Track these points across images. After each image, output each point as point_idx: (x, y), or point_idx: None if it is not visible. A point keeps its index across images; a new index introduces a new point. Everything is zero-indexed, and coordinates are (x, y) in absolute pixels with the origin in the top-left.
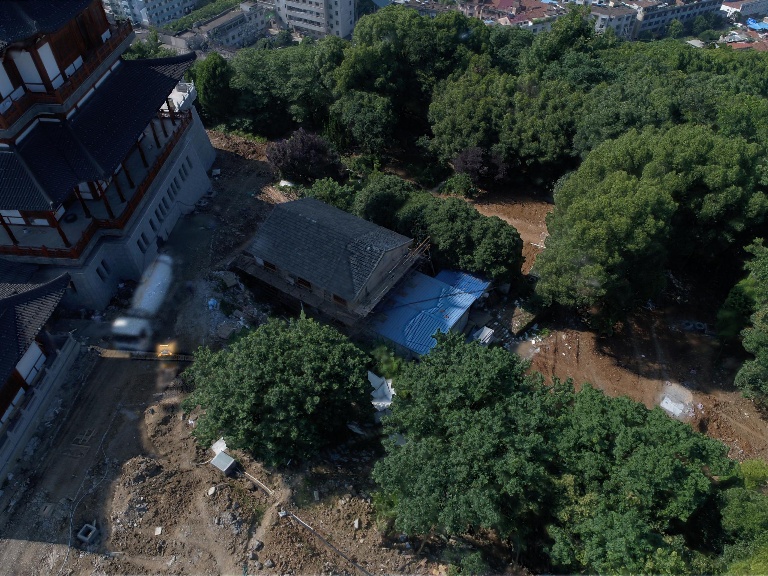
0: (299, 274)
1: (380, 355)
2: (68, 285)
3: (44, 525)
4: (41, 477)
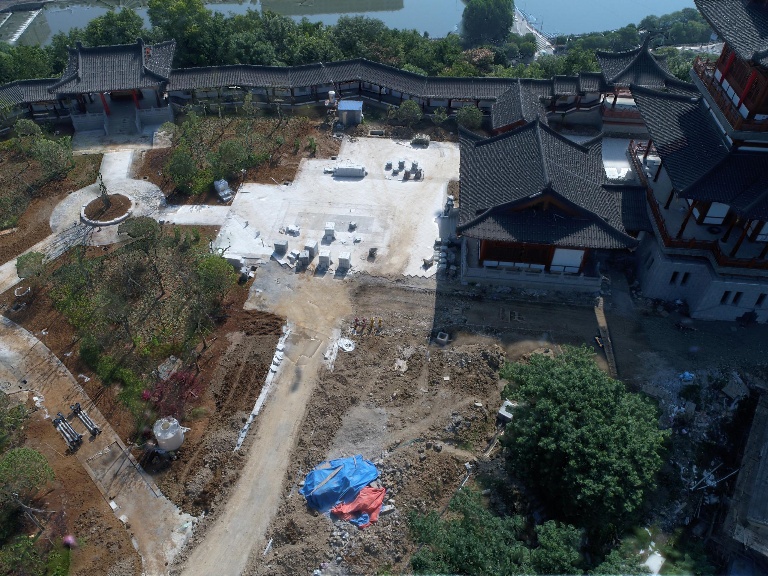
0: (767, 452)
1: (688, 568)
2: (632, 248)
3: (446, 313)
4: (481, 301)
